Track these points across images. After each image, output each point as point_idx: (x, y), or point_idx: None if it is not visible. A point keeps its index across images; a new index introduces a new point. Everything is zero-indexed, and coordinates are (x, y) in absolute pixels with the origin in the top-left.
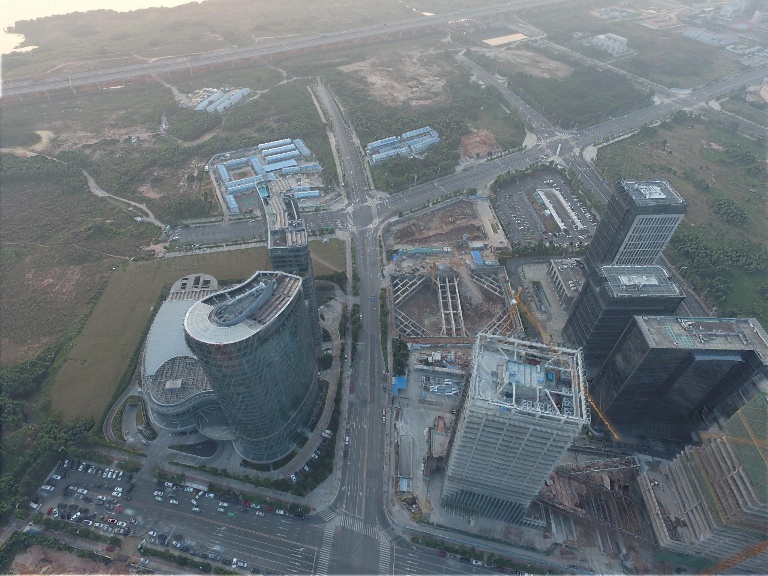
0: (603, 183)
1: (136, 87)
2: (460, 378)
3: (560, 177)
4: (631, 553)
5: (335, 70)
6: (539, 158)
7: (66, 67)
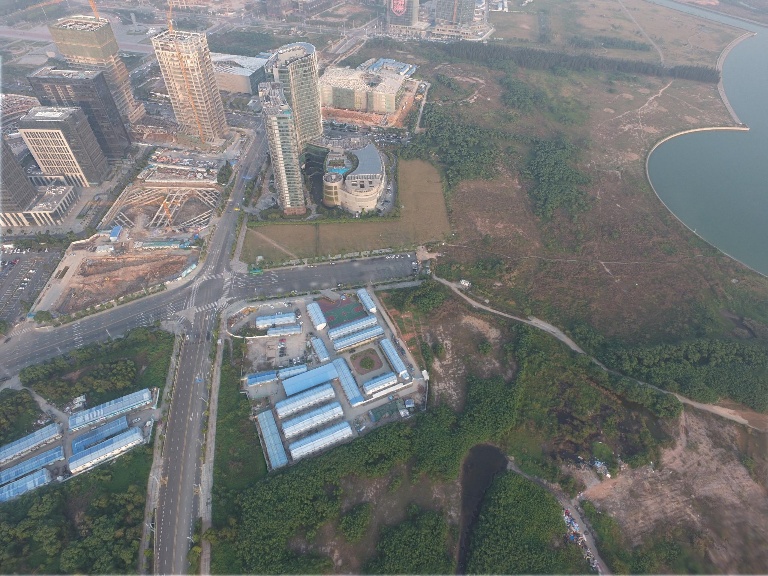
0: None
1: None
2: None
3: None
4: None
5: None
6: None
7: None
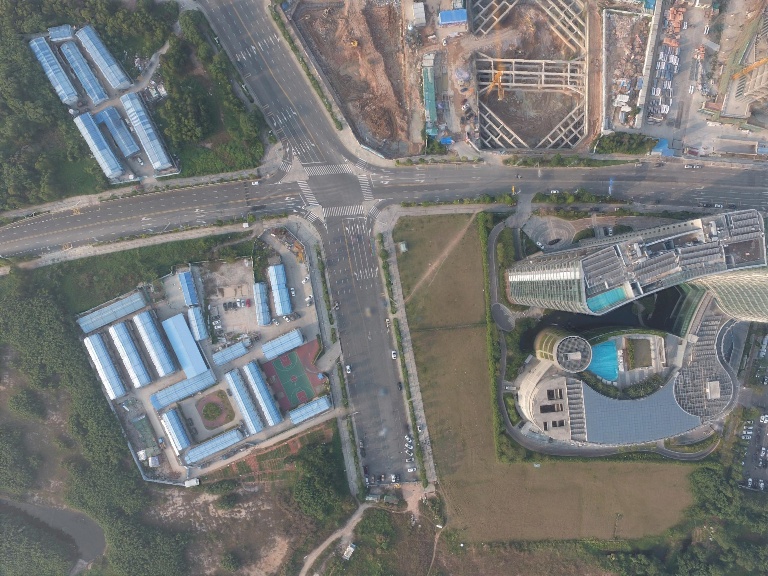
0: None
1: None
2: (650, 77)
3: None
4: None
5: None
6: None
7: None
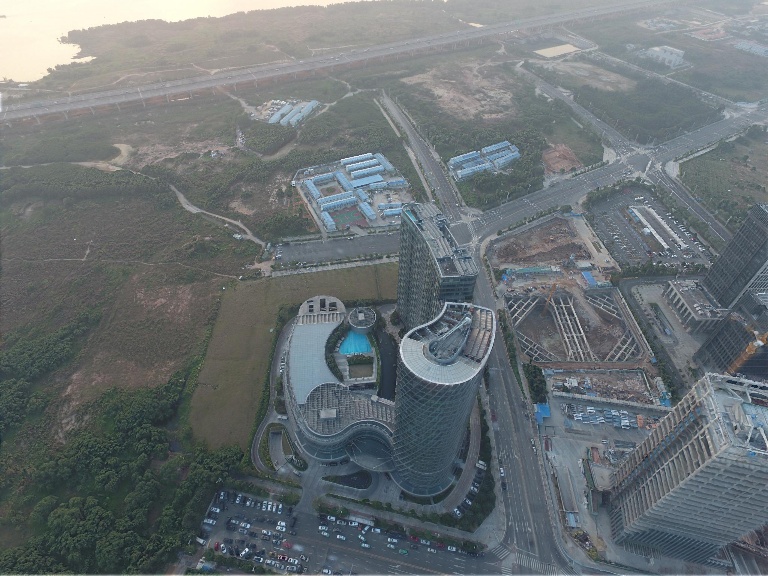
0: (694, 200)
1: (204, 99)
2: (601, 406)
3: (649, 194)
4: None
5: (398, 82)
6: (623, 174)
7: (130, 78)
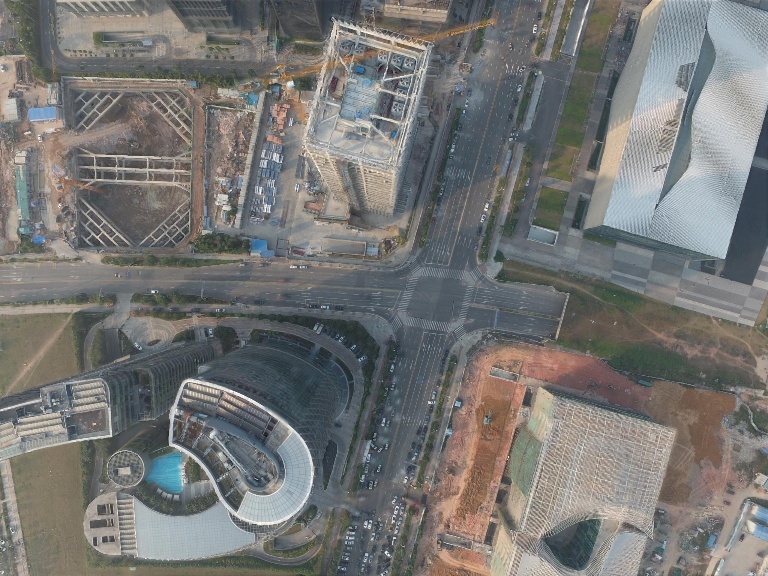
0: None
1: None
2: (254, 175)
3: None
4: (439, 51)
5: None
6: None
7: None
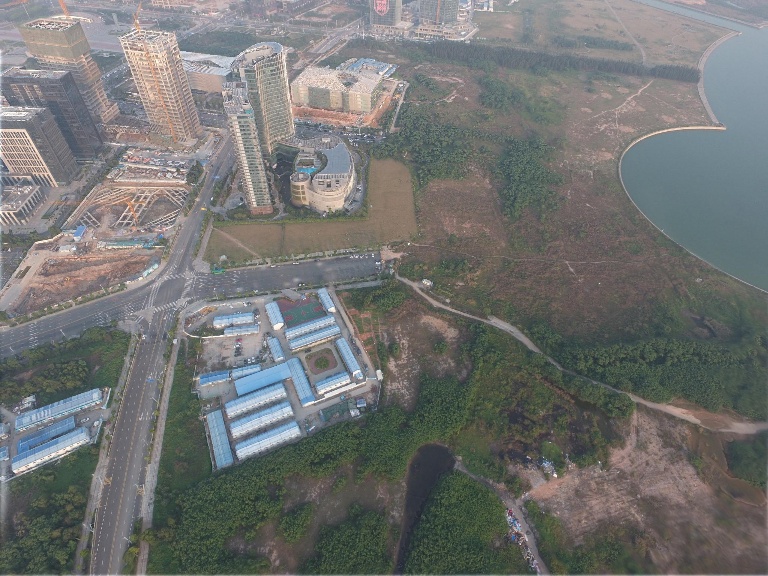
0: None
1: None
2: None
3: None
4: None
5: None
6: None
7: None
